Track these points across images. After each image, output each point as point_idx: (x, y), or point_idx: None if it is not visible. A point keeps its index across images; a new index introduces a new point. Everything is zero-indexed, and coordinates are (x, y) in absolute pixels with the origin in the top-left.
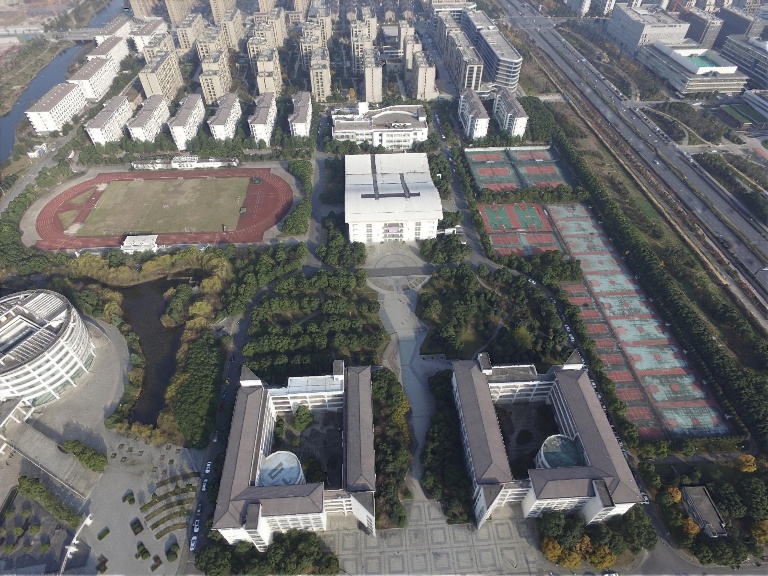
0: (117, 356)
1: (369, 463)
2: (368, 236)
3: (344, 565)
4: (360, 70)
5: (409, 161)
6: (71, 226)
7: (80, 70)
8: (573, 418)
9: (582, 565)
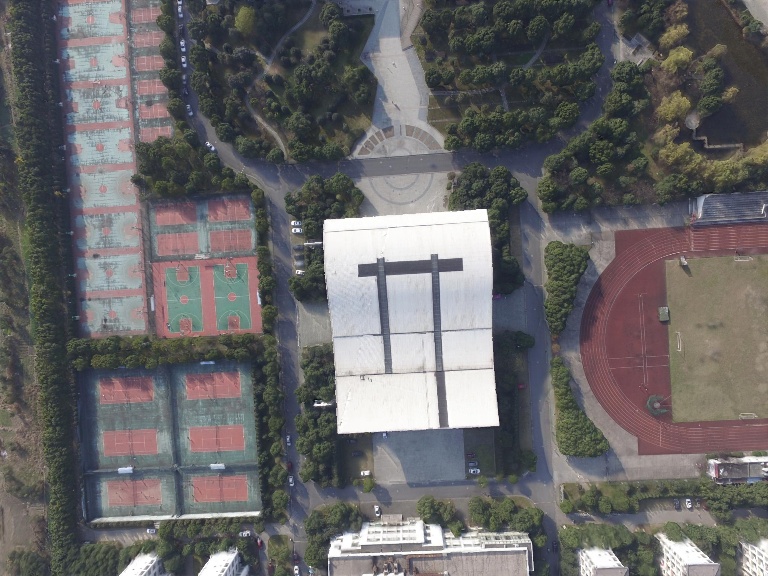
0: (761, 2)
1: None
2: None
3: None
4: None
5: (373, 410)
6: None
7: None
8: None
9: None
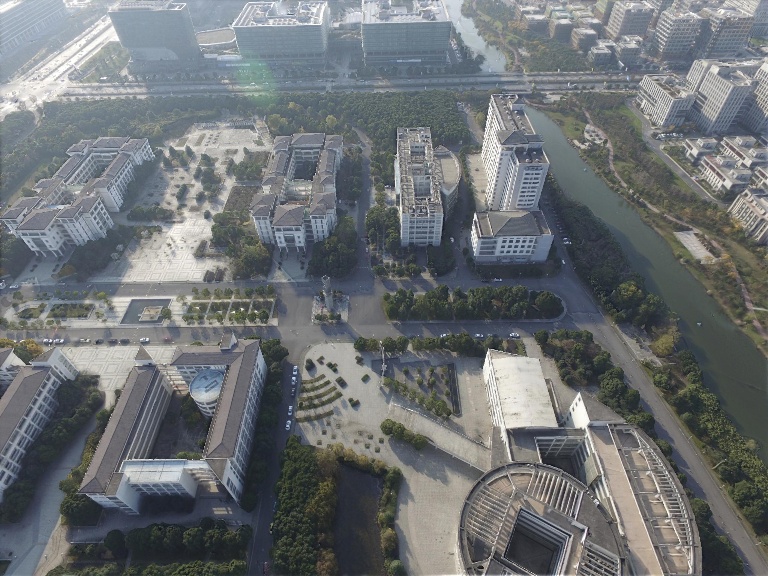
0: None
1: (129, 385)
2: None
3: None
4: None
5: None
6: None
7: None
8: None
9: None
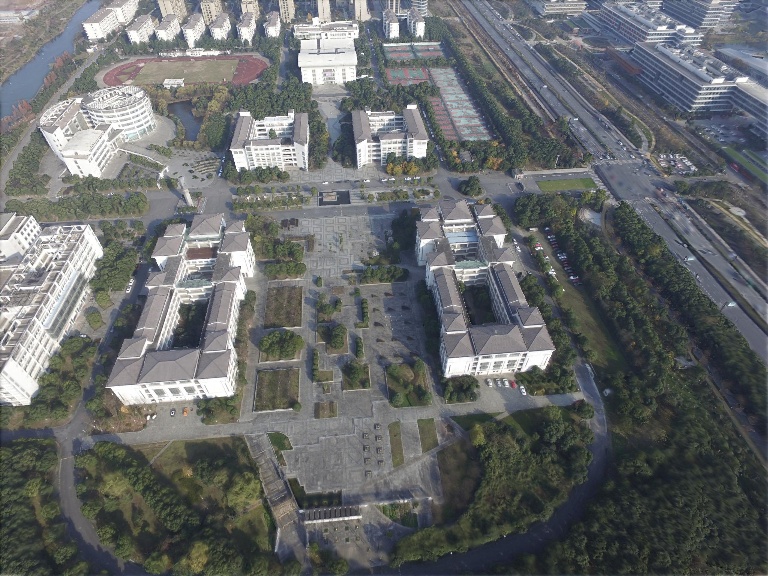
0: (169, 126)
1: (304, 137)
2: (314, 79)
3: (292, 179)
4: (316, 5)
5: (342, 43)
6: (126, 81)
7: (114, 1)
8: (406, 121)
9: (404, 176)
